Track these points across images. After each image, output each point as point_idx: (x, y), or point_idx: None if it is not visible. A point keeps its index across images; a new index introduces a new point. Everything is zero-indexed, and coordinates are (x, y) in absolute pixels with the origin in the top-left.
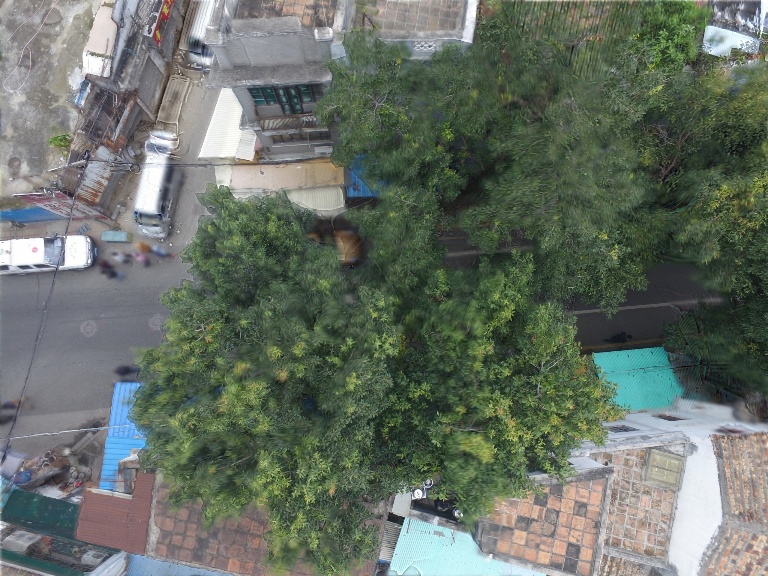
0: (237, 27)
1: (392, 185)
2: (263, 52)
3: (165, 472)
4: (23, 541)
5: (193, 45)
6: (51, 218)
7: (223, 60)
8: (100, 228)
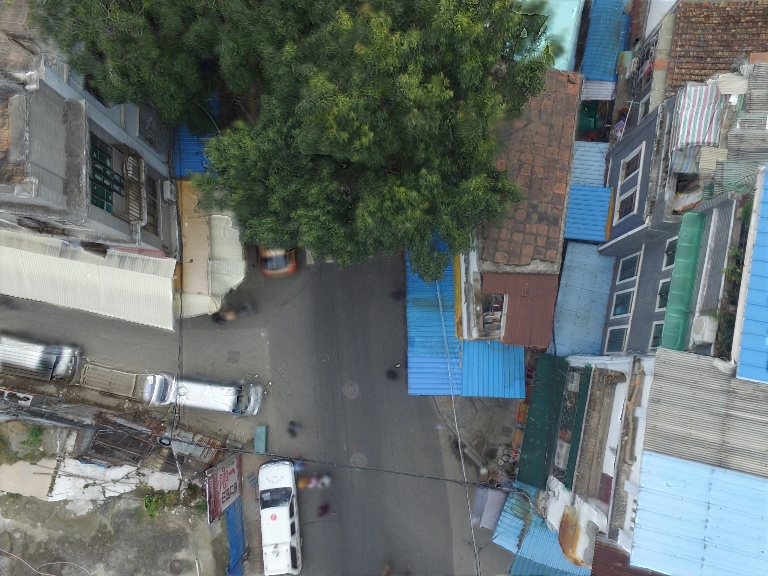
0: (16, 155)
1: (195, 26)
2: (48, 155)
3: (480, 261)
4: (563, 450)
5: (46, 364)
6: (240, 514)
7: (55, 200)
8: (252, 461)
